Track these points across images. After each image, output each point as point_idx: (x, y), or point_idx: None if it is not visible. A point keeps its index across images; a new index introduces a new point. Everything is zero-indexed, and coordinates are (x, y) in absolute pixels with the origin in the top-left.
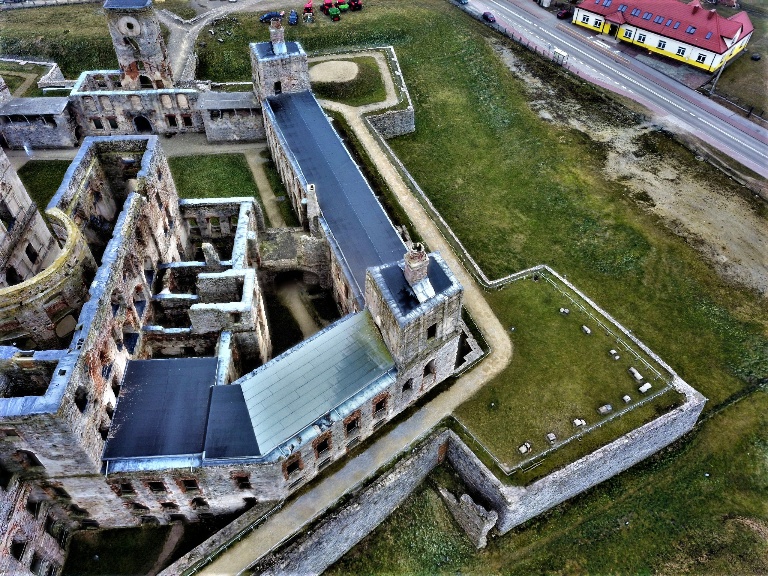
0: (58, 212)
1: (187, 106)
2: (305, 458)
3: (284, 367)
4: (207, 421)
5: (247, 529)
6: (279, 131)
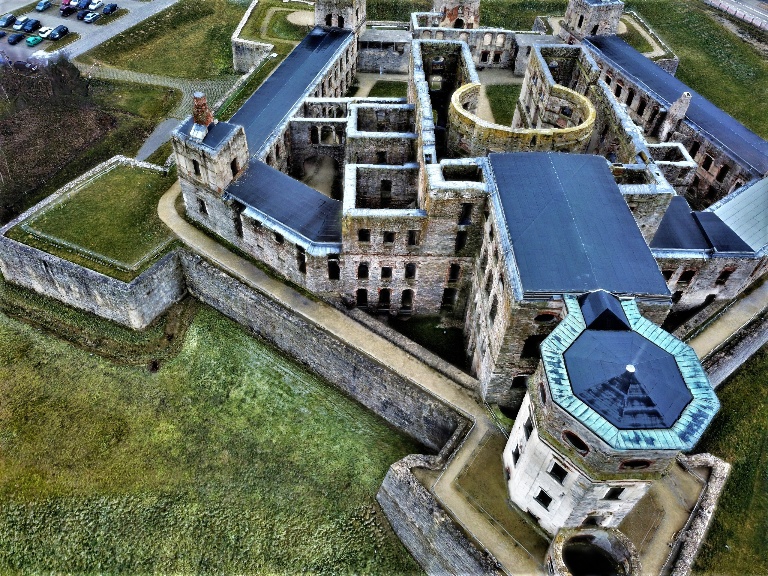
0: (564, 87)
1: (499, 45)
2: (760, 266)
3: (736, 204)
4: (704, 231)
5: (720, 313)
6: (610, 62)
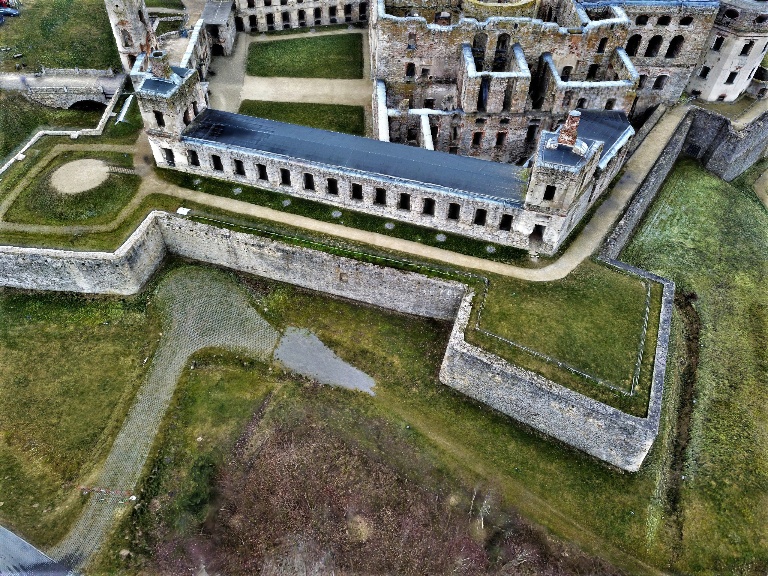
0: None
1: None
2: None
3: None
4: None
5: None
6: None
